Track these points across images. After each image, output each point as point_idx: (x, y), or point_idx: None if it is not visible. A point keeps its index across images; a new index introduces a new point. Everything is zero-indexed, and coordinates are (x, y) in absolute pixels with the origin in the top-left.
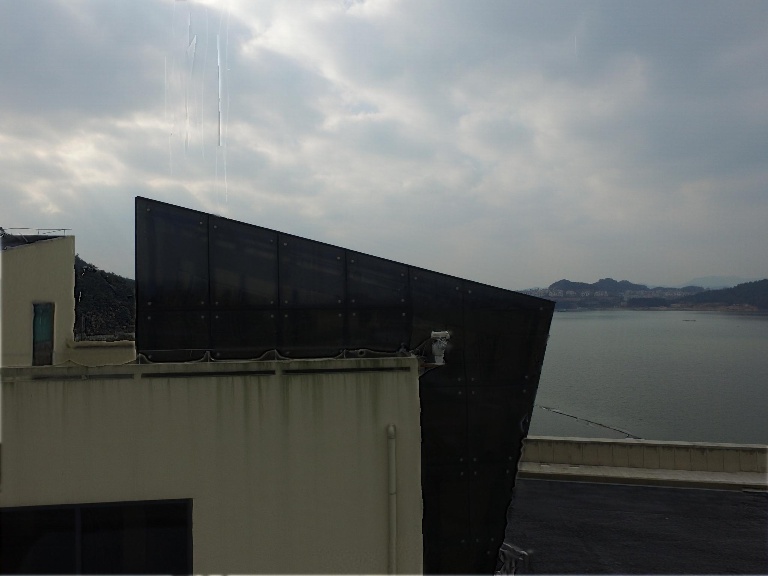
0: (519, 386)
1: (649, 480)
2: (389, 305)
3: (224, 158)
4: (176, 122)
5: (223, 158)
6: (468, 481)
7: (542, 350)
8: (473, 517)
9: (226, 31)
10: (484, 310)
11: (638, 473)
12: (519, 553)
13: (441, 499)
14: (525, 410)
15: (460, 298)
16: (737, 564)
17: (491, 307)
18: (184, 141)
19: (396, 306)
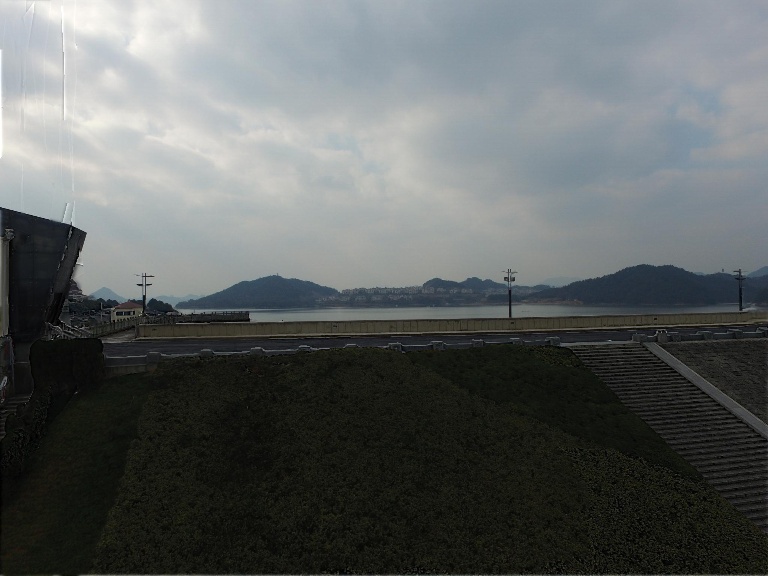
0: (56, 254)
1: (227, 338)
2: (1, 223)
3: (70, 140)
4: (9, 95)
5: (69, 140)
6: (34, 285)
7: (66, 241)
8: (38, 299)
9: (73, 2)
10: (46, 228)
11: (226, 336)
12: (89, 333)
13: (27, 294)
14: (59, 262)
15: (32, 222)
16: (209, 347)
17: (49, 227)
18: (19, 117)
19: (4, 224)
